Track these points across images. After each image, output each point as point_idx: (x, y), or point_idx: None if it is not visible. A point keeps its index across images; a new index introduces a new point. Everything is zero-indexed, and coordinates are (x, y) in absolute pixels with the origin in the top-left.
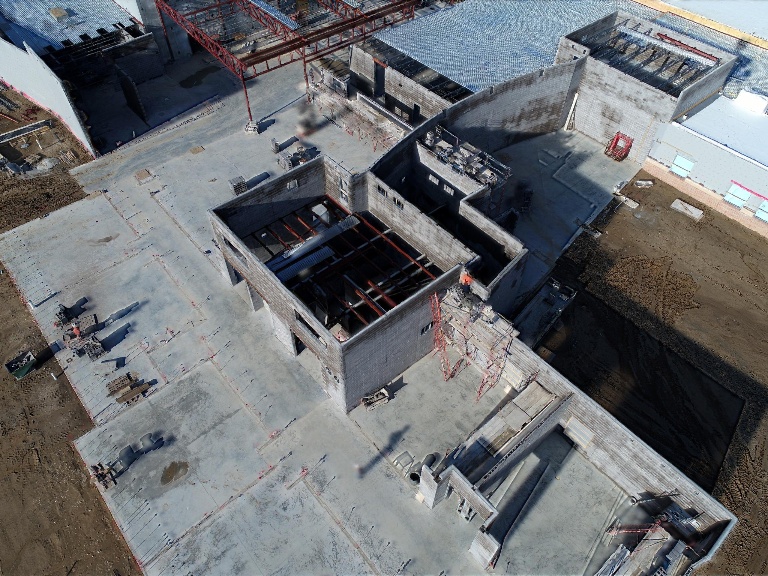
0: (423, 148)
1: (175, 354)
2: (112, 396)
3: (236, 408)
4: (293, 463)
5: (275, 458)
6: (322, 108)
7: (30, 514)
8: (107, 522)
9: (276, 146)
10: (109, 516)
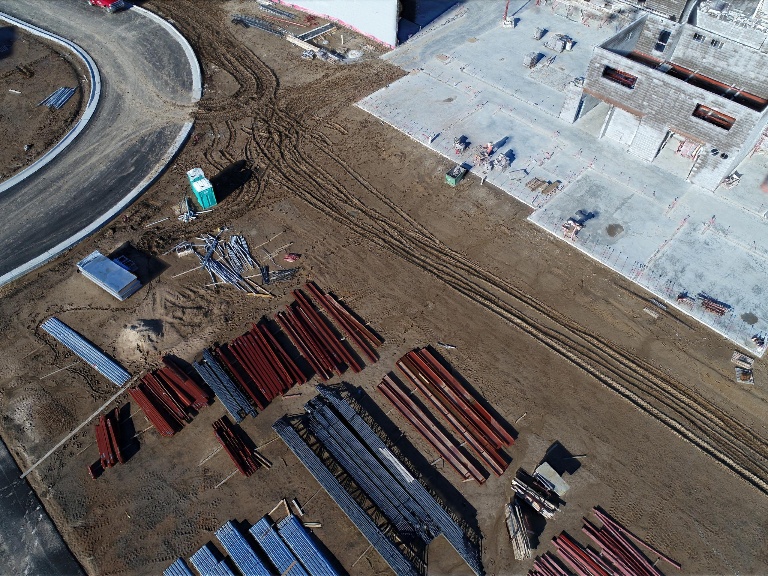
0: (704, 12)
1: (561, 165)
2: (535, 191)
3: (631, 193)
4: (695, 221)
5: (680, 219)
6: (556, 7)
7: (528, 259)
8: (587, 259)
9: (540, 33)
10: (586, 256)
